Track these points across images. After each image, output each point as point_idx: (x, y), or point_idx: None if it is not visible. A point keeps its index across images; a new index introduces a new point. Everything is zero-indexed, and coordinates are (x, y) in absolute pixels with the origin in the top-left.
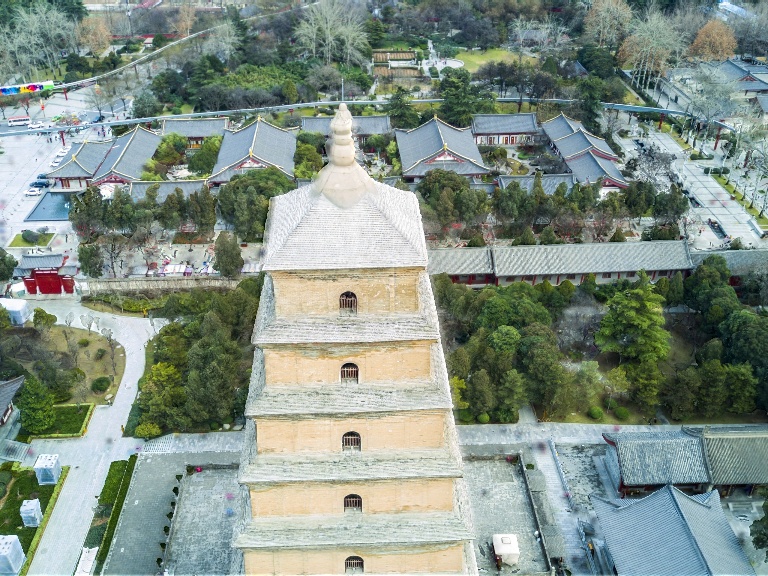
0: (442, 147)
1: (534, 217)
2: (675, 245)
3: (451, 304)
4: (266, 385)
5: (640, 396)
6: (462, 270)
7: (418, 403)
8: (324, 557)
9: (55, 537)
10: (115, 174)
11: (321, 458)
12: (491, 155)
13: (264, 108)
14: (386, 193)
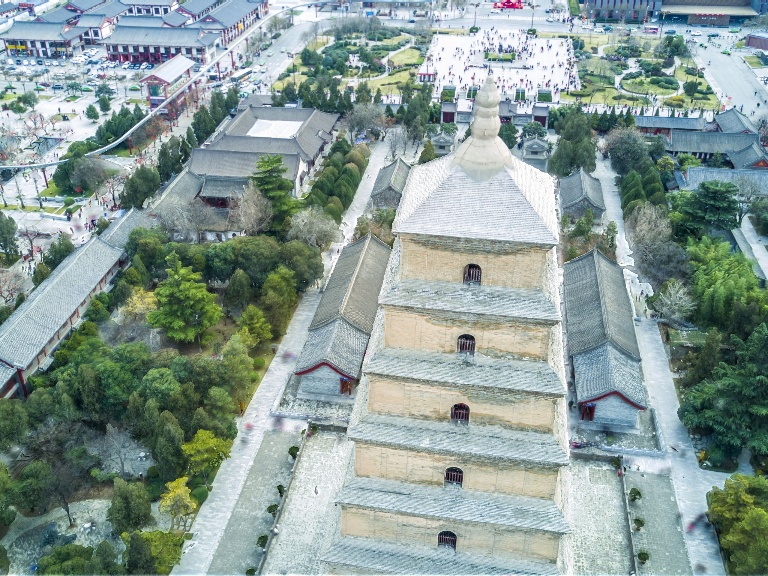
0: None
1: None
2: (95, 244)
3: (57, 412)
4: None
5: None
6: None
7: None
8: None
9: None
10: None
11: None
12: None
13: None
14: None
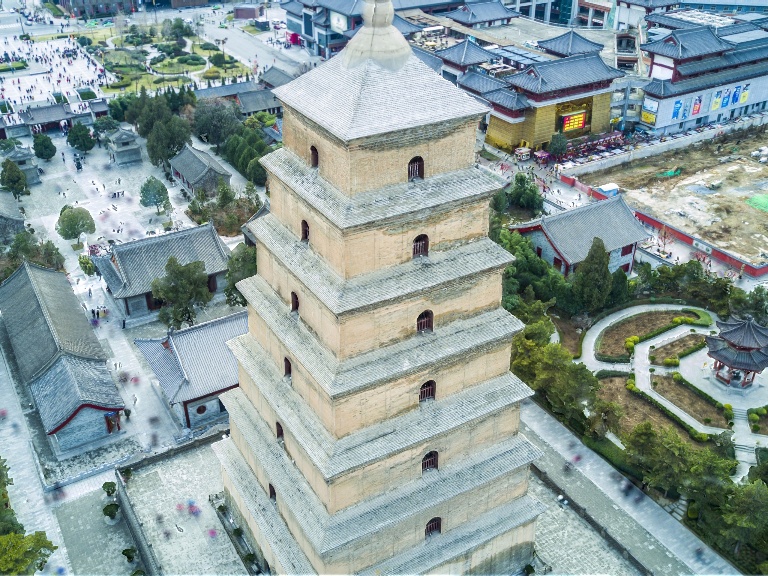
0: None
1: None
2: None
3: None
4: None
5: None
6: None
7: None
8: None
9: None
10: None
11: None
12: None
13: None
14: None
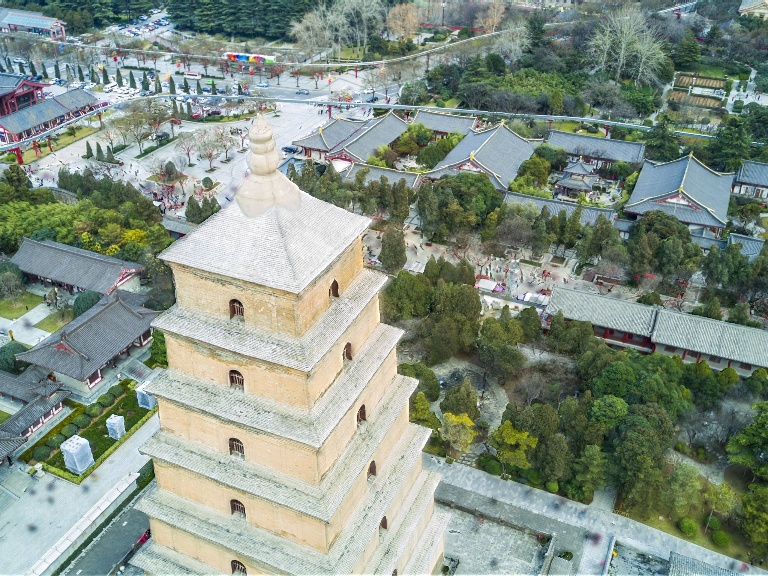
0: (677, 188)
1: (751, 289)
2: None
3: (577, 356)
4: (169, 368)
5: (744, 526)
6: (615, 324)
7: (289, 431)
8: (213, 551)
9: (126, 453)
10: (346, 152)
11: (210, 454)
12: (740, 209)
13: (520, 114)
14: (317, 212)
